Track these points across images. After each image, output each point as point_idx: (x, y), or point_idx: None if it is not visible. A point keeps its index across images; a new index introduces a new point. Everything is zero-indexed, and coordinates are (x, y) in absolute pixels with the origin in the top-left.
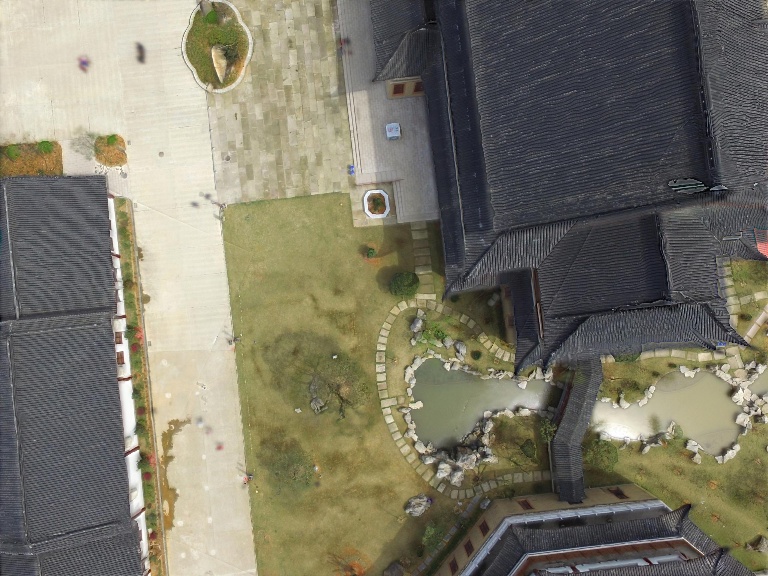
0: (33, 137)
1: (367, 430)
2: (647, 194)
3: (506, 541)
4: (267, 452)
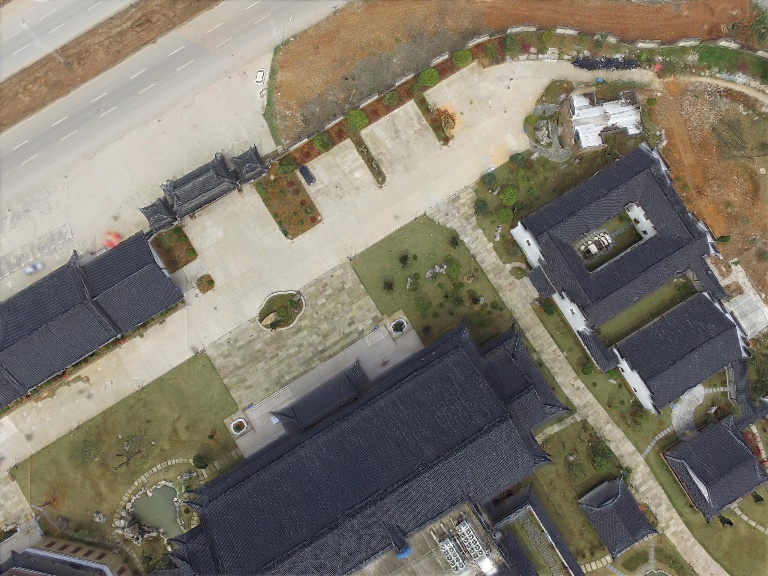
0: (195, 243)
1: (126, 475)
2: (220, 568)
3: (90, 572)
4: (93, 431)
